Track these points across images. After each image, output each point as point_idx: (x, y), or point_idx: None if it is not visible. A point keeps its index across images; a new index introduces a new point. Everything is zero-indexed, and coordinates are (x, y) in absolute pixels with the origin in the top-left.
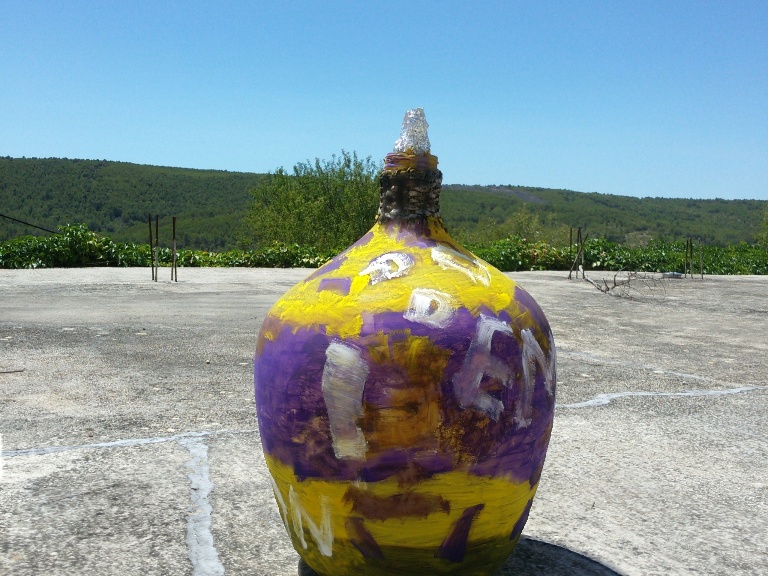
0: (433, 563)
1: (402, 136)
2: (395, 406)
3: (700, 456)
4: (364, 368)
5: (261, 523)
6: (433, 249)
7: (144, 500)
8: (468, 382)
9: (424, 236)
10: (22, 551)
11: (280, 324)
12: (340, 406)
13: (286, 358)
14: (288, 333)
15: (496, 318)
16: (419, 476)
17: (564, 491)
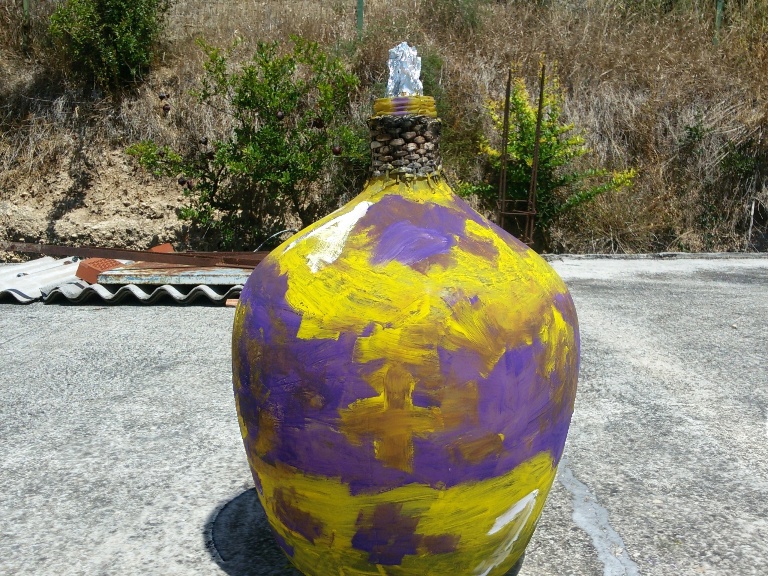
0: None
1: None
2: None
3: None
4: None
5: None
6: None
7: None
8: None
9: None
10: None
11: None
12: None
13: None
14: None
15: None
16: None
17: None
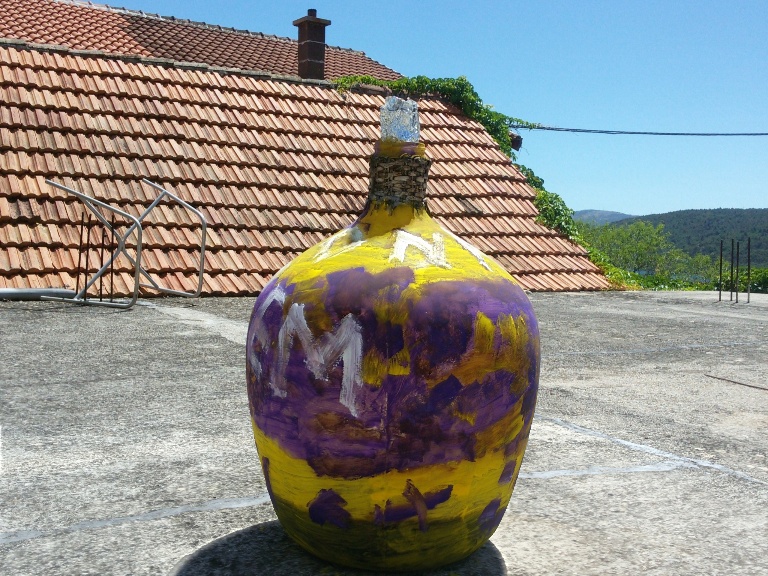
0: None
1: None
2: None
3: None
4: None
5: None
6: (345, 230)
7: None
8: None
9: None
10: None
11: None
12: None
13: None
14: None
15: (283, 289)
16: None
17: None
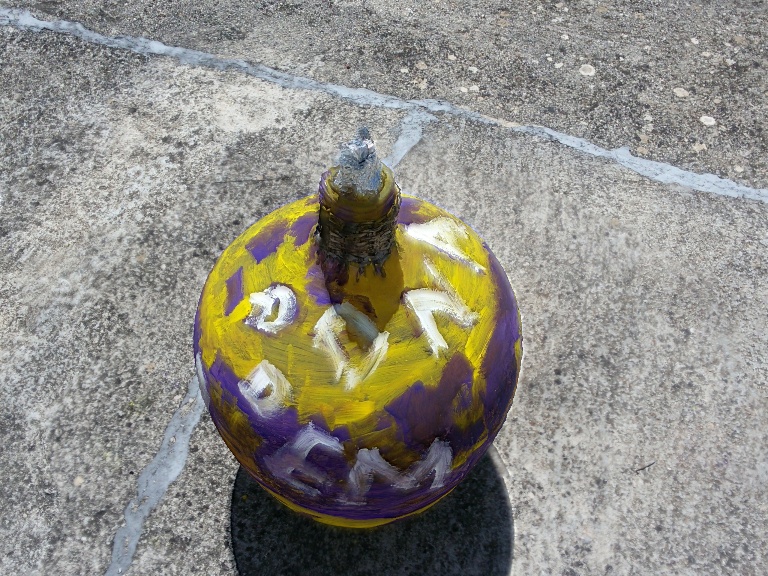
0: None
1: None
2: (226, 437)
3: None
4: None
5: None
6: (331, 308)
7: None
8: (279, 466)
9: (336, 283)
10: (149, 251)
11: None
12: None
13: None
14: None
15: (328, 432)
16: None
17: (652, 423)
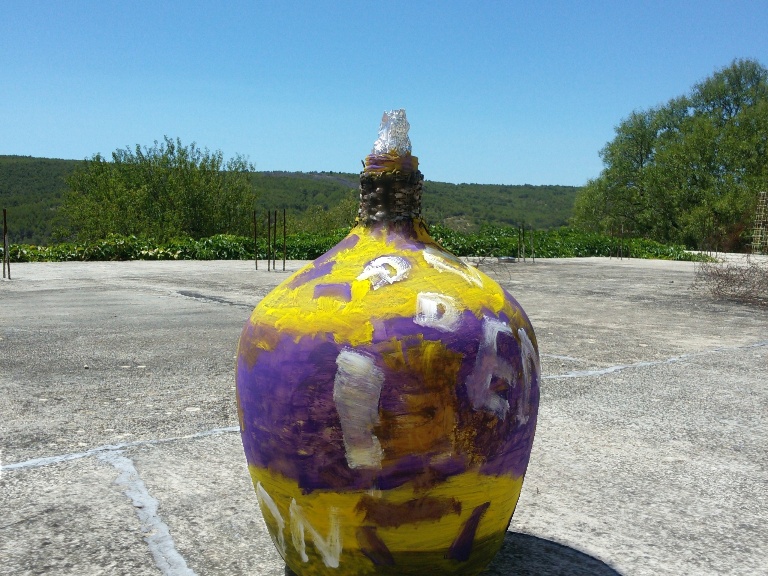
0: (442, 564)
1: (380, 137)
2: (412, 412)
3: (609, 435)
4: (379, 375)
5: (227, 538)
6: (424, 251)
7: (89, 524)
8: (479, 384)
9: (412, 238)
10: None
11: (277, 333)
12: (354, 415)
13: (289, 368)
14: (289, 342)
15: (497, 319)
16: (434, 480)
17: None
